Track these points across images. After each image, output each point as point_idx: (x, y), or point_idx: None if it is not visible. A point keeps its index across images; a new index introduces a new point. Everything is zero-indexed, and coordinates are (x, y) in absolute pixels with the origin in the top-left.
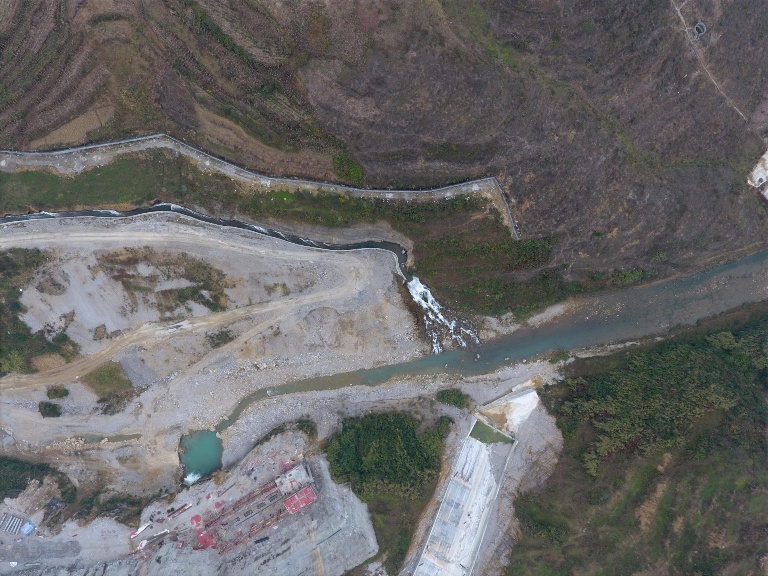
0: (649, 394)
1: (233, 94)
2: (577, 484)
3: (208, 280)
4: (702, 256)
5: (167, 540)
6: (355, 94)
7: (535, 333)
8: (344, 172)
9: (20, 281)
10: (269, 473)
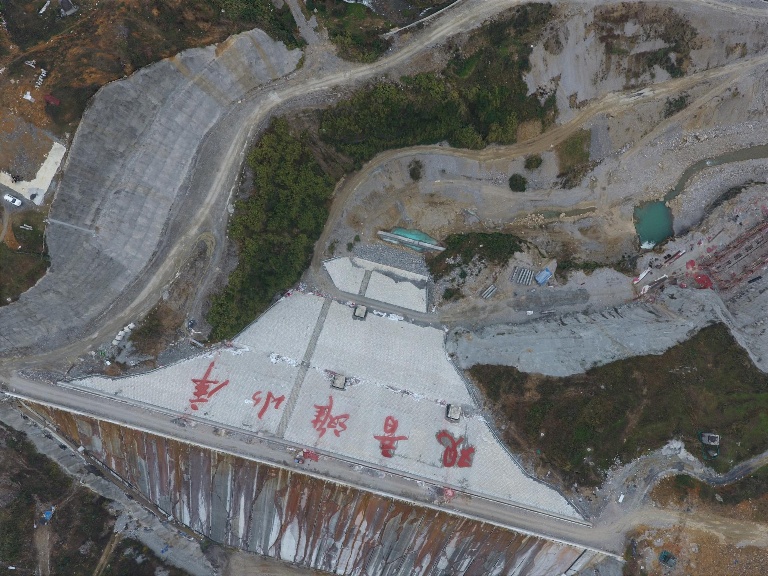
0: None
1: None
2: None
3: (680, 40)
4: None
5: (667, 284)
6: None
7: None
8: None
9: (530, 38)
10: (753, 218)
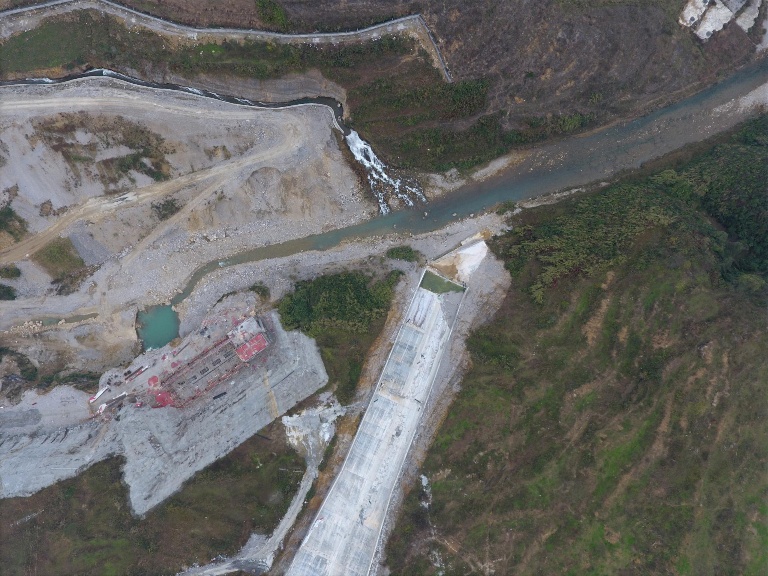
0: (592, 226)
1: None
2: (525, 313)
3: (147, 146)
4: (640, 99)
5: (126, 402)
6: None
7: (481, 188)
8: (267, 16)
9: None
10: (222, 330)
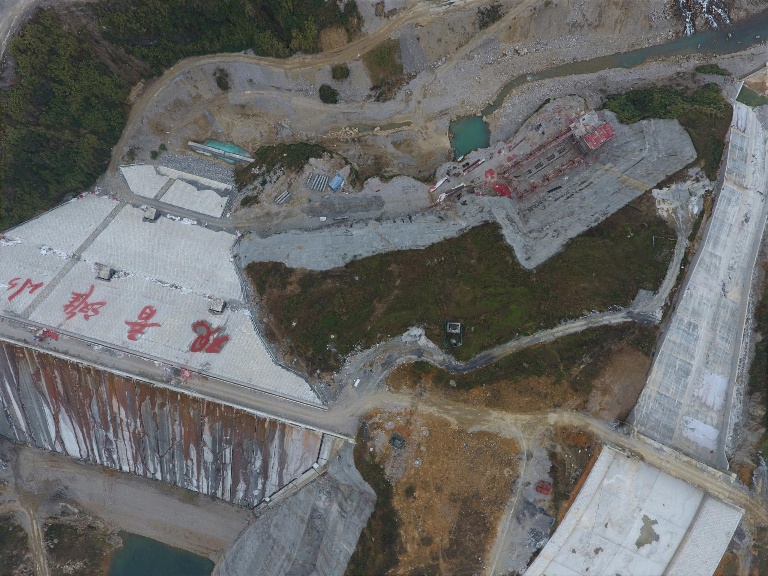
0: None
1: None
2: None
3: None
4: None
5: (464, 193)
6: None
7: None
8: None
9: None
10: (556, 127)
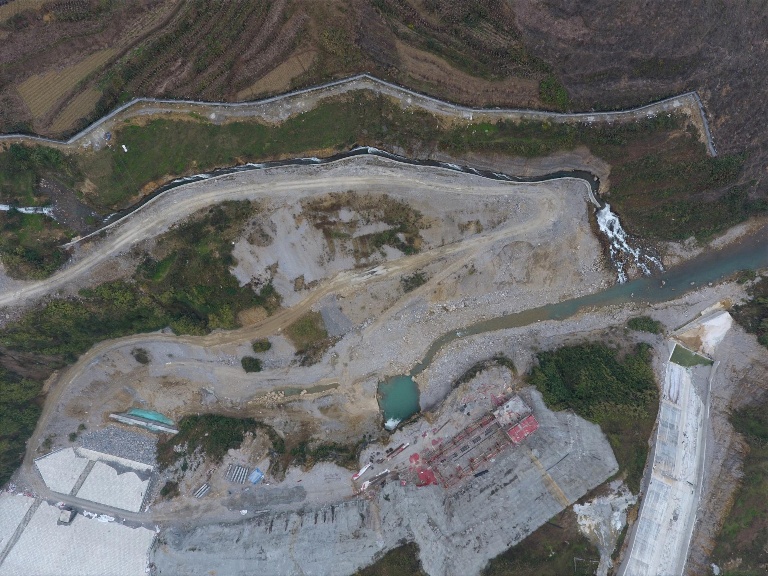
0: None
1: (438, 26)
2: None
3: (405, 222)
4: None
5: (388, 480)
6: (563, 14)
7: (718, 255)
8: (550, 97)
9: (231, 234)
10: (481, 408)
